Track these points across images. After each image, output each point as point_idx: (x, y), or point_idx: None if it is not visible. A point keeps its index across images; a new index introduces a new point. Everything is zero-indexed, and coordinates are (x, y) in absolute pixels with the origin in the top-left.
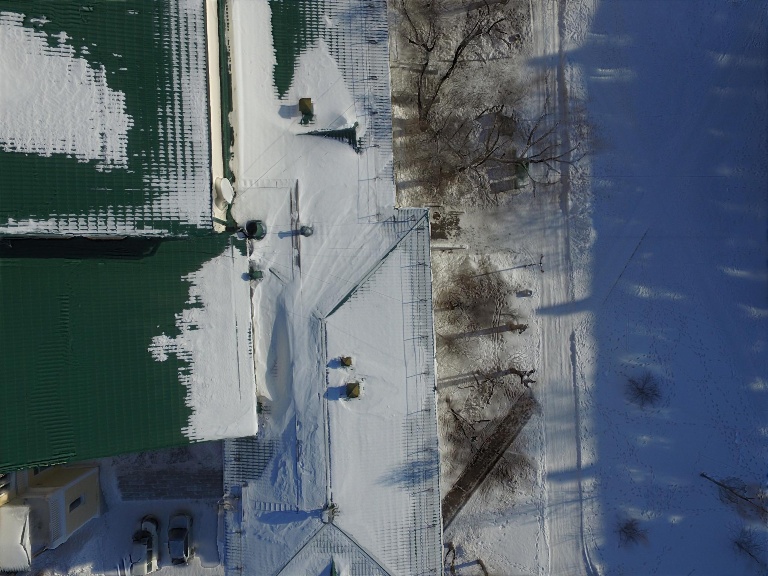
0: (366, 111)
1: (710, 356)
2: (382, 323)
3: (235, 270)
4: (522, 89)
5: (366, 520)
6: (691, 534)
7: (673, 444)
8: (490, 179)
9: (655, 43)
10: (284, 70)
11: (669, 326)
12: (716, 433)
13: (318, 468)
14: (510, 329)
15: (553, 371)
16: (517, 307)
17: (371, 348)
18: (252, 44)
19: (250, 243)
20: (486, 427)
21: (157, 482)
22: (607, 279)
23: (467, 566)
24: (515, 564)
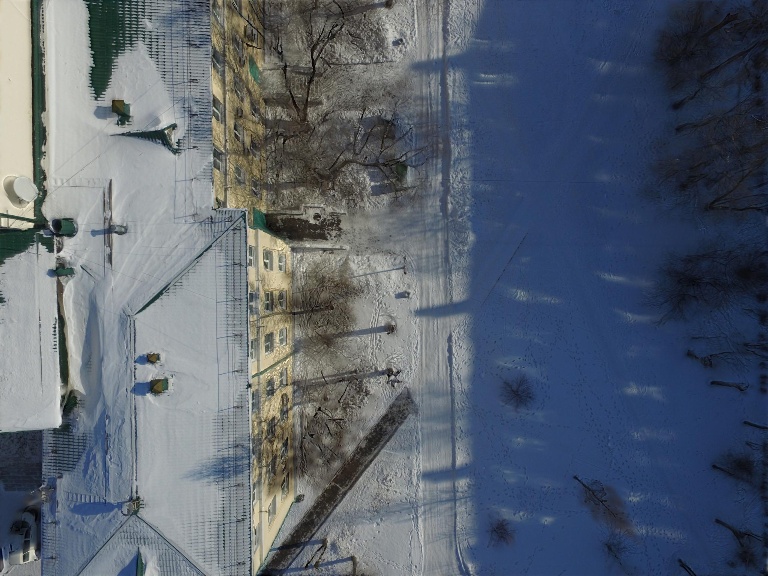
0: (186, 113)
1: (585, 360)
2: (194, 321)
3: (40, 266)
4: (406, 93)
5: (172, 513)
6: (562, 535)
7: (547, 446)
8: (371, 181)
9: (537, 50)
10: (101, 72)
11: (545, 330)
12: (589, 436)
13: (125, 461)
14: (388, 330)
15: (430, 372)
16: (395, 308)
17: (182, 345)
18: (67, 46)
19: (60, 240)
20: (363, 426)
21: (38, 473)
22: (485, 282)
23: (341, 562)
24: (388, 561)
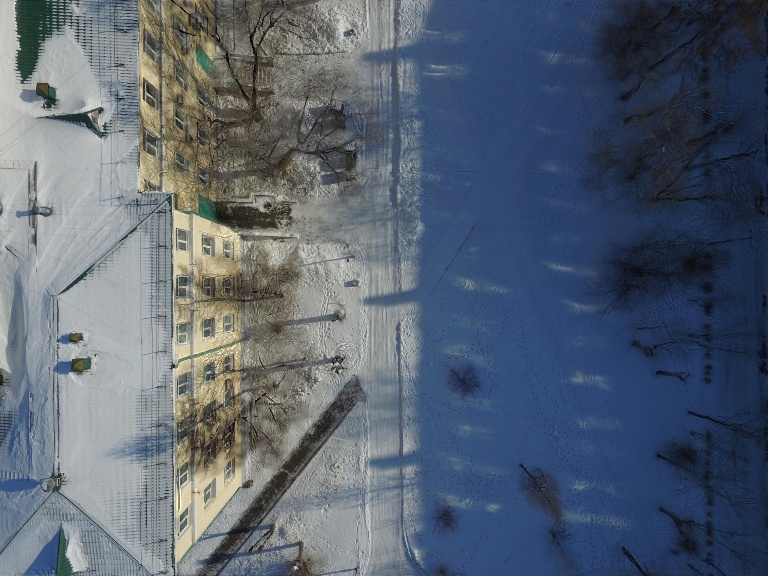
0: (112, 97)
1: (532, 350)
2: (118, 302)
3: None
4: (357, 83)
5: (95, 490)
6: (508, 523)
7: (494, 434)
8: (322, 171)
9: (487, 41)
10: (28, 55)
11: (493, 319)
12: (535, 425)
13: (47, 439)
14: None
15: (379, 360)
16: (345, 296)
17: (105, 325)
18: None
19: None
20: (312, 413)
21: None
22: (434, 272)
23: (289, 547)
24: (336, 547)
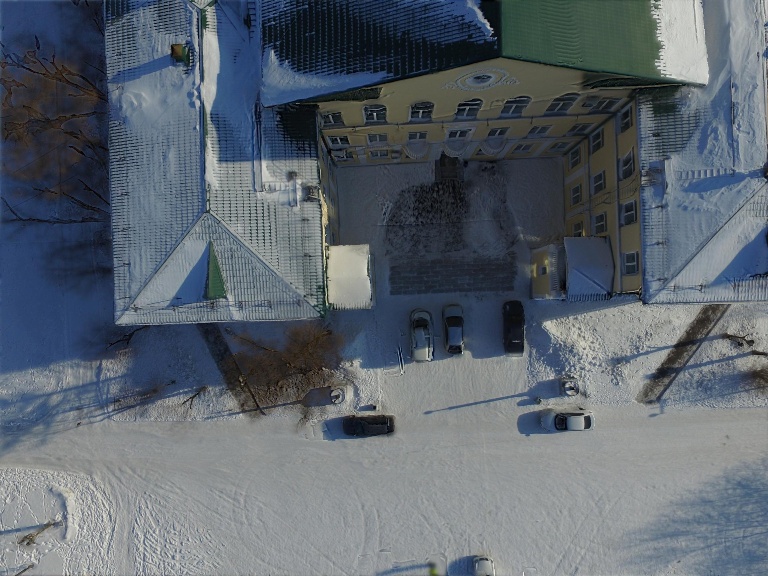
0: None
1: None
2: None
3: None
4: None
5: None
6: None
7: None
8: None
9: None
10: None
11: None
12: None
13: (757, 127)
14: None
15: None
16: None
17: None
18: None
19: None
20: None
21: (430, 272)
22: None
23: (742, 357)
24: None
